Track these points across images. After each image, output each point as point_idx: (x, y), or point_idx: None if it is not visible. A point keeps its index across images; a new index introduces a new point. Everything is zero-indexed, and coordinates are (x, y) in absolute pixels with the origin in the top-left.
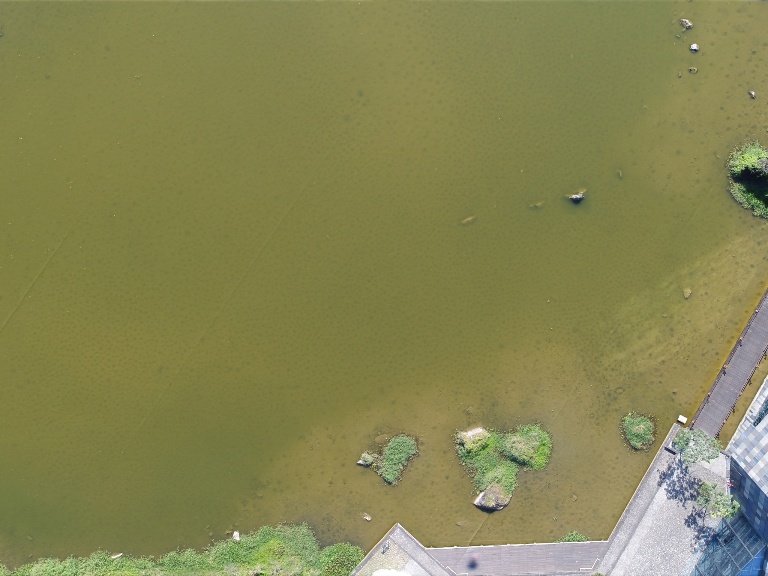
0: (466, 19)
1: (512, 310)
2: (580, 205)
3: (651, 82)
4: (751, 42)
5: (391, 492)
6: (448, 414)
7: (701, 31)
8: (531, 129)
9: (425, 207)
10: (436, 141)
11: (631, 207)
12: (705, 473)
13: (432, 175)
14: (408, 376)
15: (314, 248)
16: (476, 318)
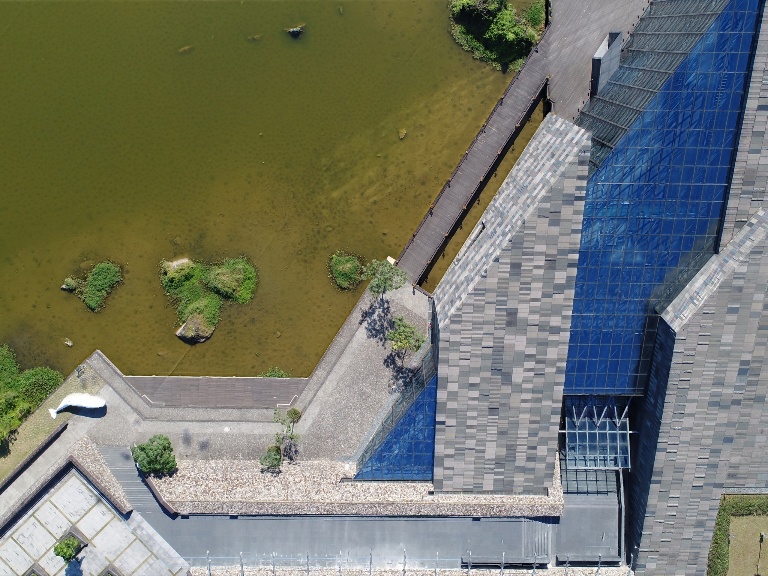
0: None
1: (225, 142)
2: (299, 40)
3: None
4: None
5: (94, 319)
6: (155, 243)
7: None
8: None
9: (142, 34)
10: None
11: (350, 44)
12: (407, 314)
13: (151, 2)
14: (117, 203)
15: (29, 70)
16: (188, 148)
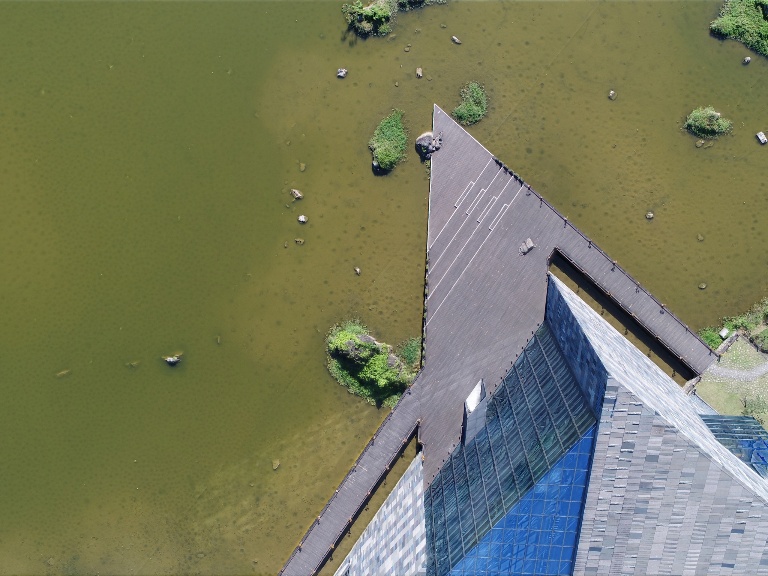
0: (76, 172)
1: (100, 466)
2: (176, 367)
3: (257, 250)
4: (361, 218)
5: None
6: (29, 563)
7: (311, 203)
8: (133, 287)
9: (21, 357)
10: (37, 292)
11: (227, 374)
12: None
13: (31, 325)
14: None
15: None
16: (64, 471)
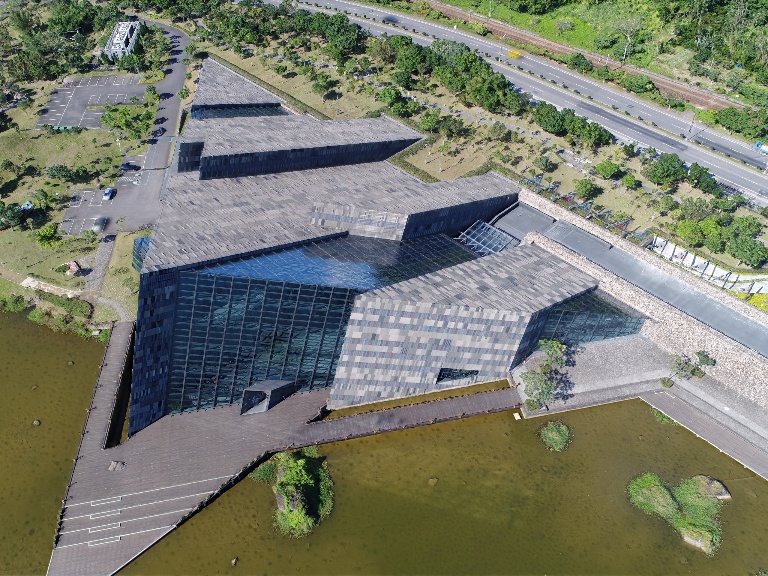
0: None
1: None
2: None
3: None
4: None
5: None
6: (709, 575)
7: None
8: None
9: None
10: None
11: None
12: None
13: None
14: None
15: None
16: None
